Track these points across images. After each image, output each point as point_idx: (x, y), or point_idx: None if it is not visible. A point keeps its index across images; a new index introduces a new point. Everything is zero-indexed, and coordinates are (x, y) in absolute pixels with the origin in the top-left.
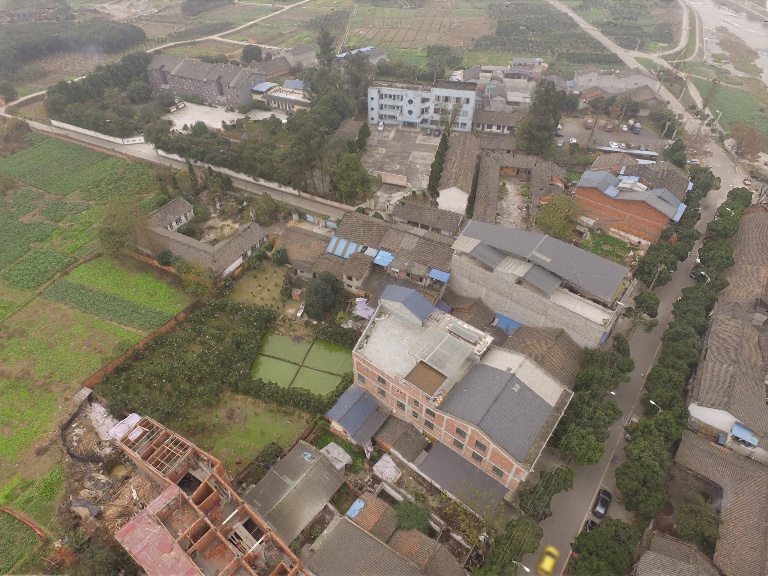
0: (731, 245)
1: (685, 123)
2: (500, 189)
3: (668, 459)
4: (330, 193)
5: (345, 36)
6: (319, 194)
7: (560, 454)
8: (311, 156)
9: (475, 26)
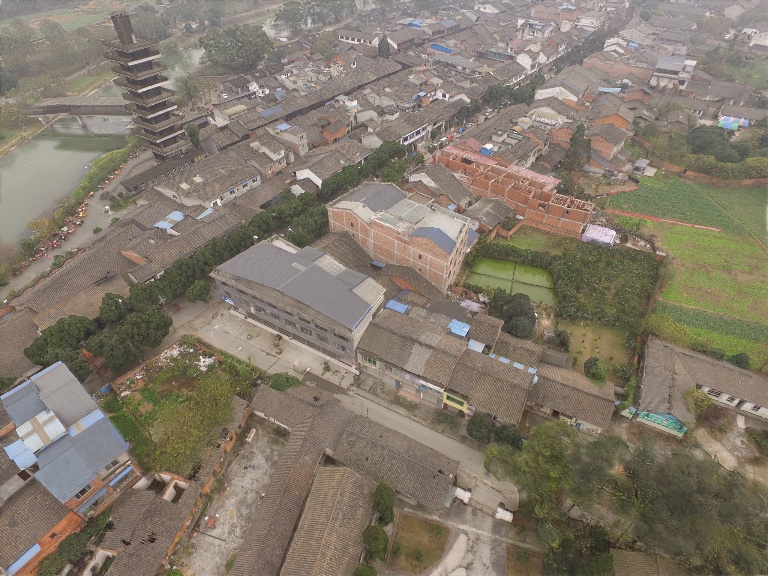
0: None
1: None
2: None
3: None
4: None
5: None
6: None
7: None
8: None
9: None
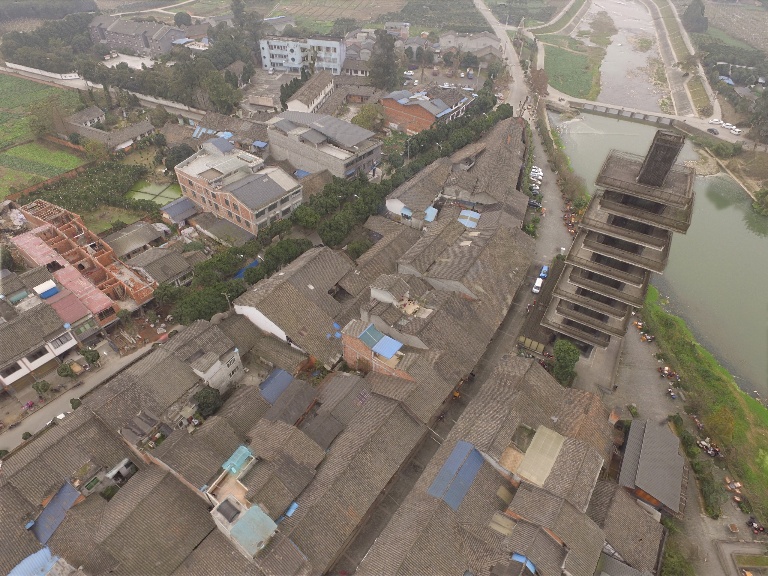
0: (483, 138)
1: (505, 70)
2: (344, 110)
3: (359, 226)
4: (210, 107)
5: (272, 11)
6: (203, 108)
7: (303, 230)
8: (192, 77)
9: (388, 6)
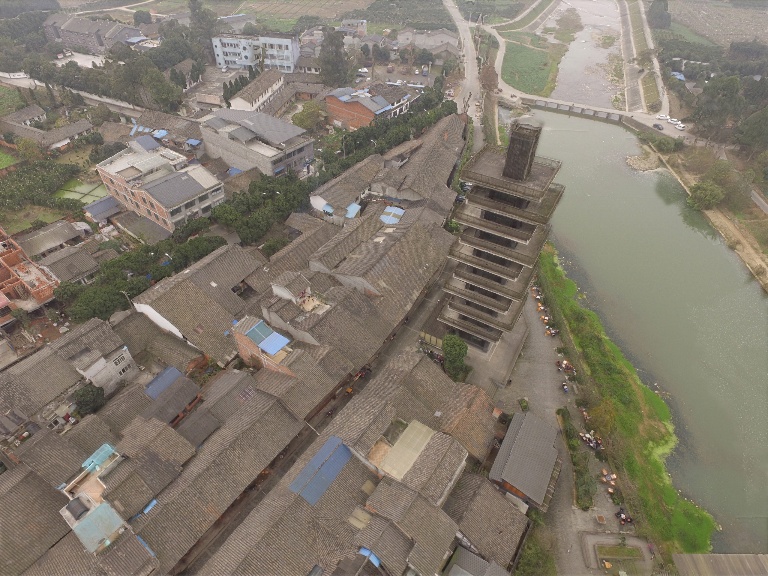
0: (424, 134)
1: None
2: (292, 107)
3: (280, 223)
4: (154, 105)
5: (237, 9)
6: (147, 107)
7: (226, 228)
8: (134, 75)
9: (356, 3)
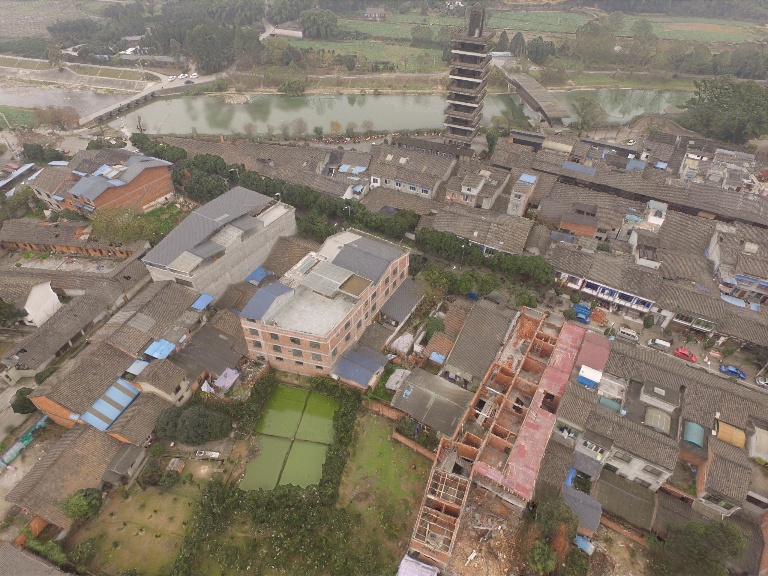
0: None
1: None
2: None
3: None
4: None
5: None
6: None
7: None
8: None
9: None
